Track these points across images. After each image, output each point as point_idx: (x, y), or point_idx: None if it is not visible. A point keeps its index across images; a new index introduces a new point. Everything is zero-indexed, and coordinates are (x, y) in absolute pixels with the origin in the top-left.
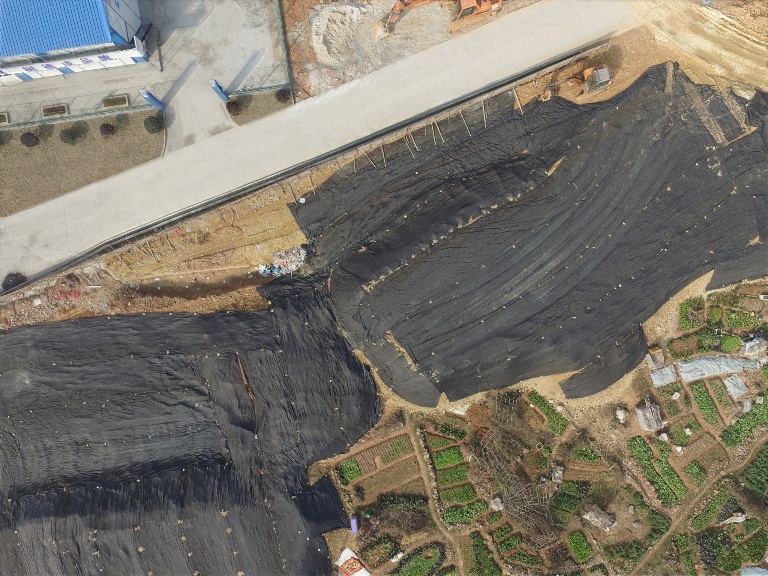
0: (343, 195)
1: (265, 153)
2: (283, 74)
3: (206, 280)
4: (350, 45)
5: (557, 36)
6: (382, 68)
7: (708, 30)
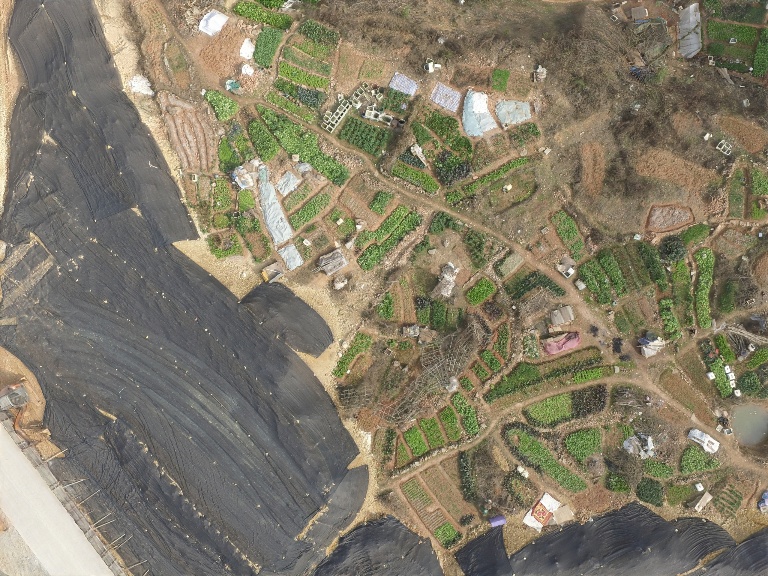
0: None
1: None
2: None
3: None
4: None
5: None
6: None
7: None
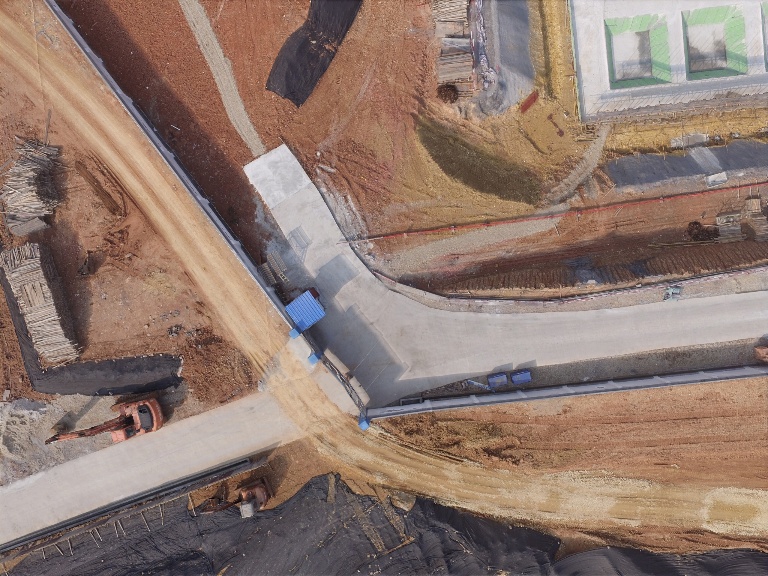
0: None
1: None
2: None
3: None
4: (33, 441)
5: (226, 444)
6: (65, 462)
7: (369, 442)
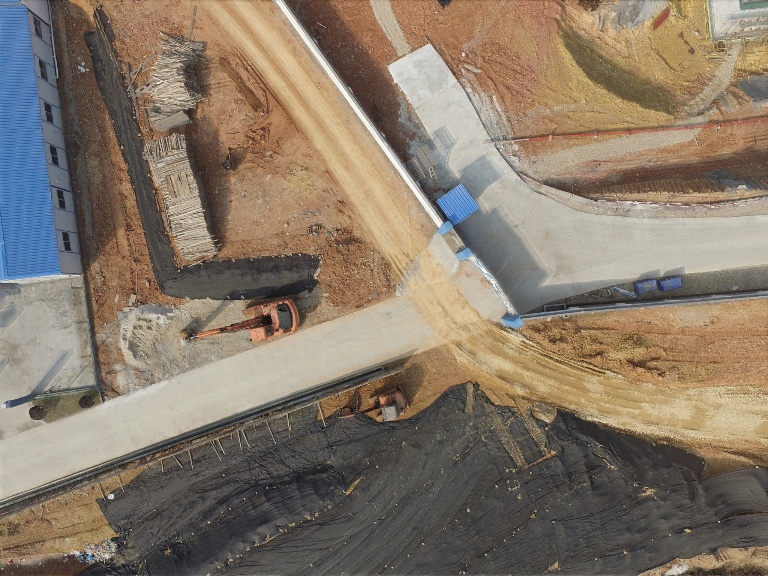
0: (151, 493)
1: (74, 450)
2: (91, 375)
3: (22, 562)
4: (158, 347)
5: (359, 351)
6: (190, 371)
7: (509, 351)
